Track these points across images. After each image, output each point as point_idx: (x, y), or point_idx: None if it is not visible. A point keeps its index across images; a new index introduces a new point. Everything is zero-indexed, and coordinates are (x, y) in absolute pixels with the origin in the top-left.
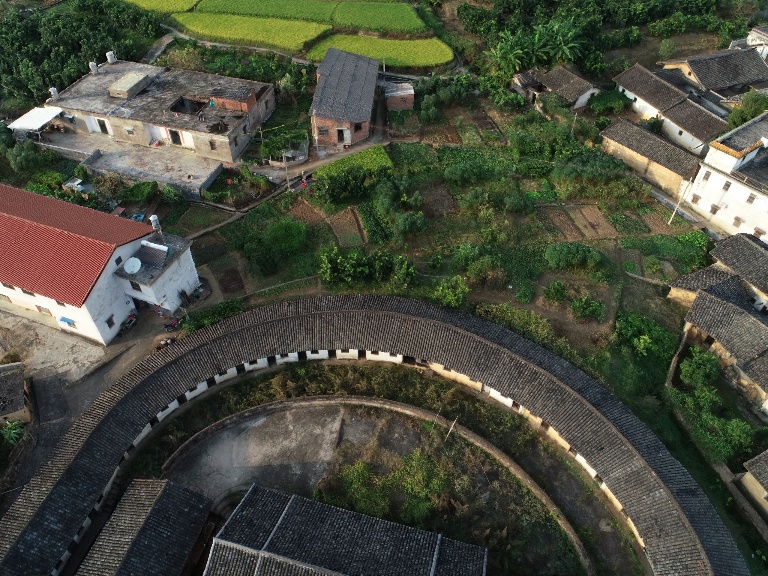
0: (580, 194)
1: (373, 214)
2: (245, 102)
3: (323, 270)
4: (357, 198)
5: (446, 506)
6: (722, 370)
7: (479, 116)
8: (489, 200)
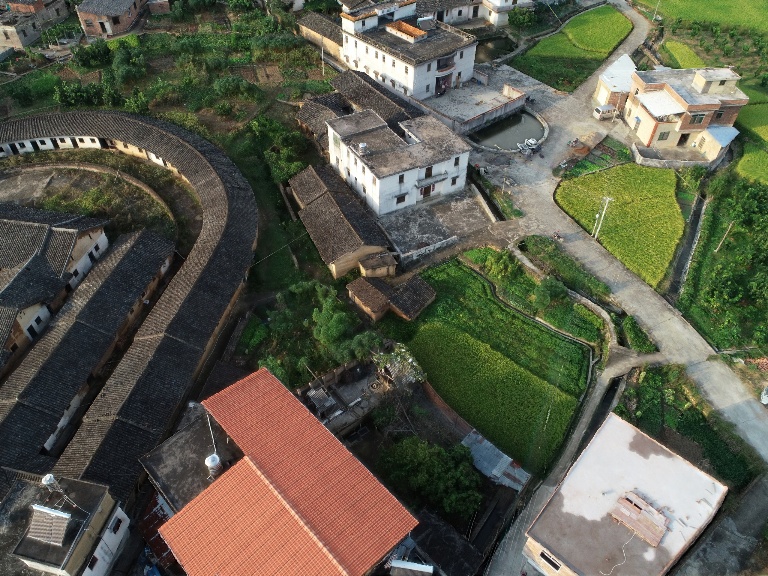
0: (266, 58)
1: (112, 73)
2: (31, 5)
3: (55, 96)
4: (105, 65)
5: (101, 210)
6: (317, 148)
7: (219, 17)
8: (194, 60)
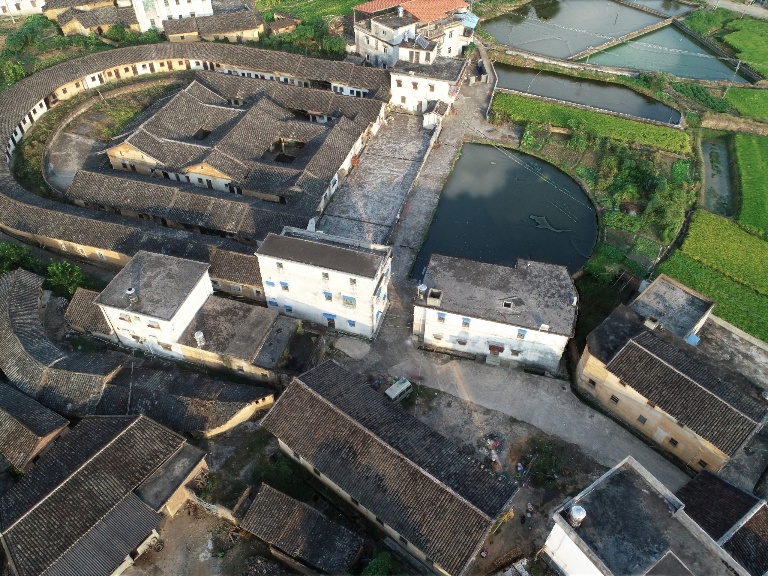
0: None
1: None
2: None
3: None
4: None
5: None
6: None
7: None
8: None
